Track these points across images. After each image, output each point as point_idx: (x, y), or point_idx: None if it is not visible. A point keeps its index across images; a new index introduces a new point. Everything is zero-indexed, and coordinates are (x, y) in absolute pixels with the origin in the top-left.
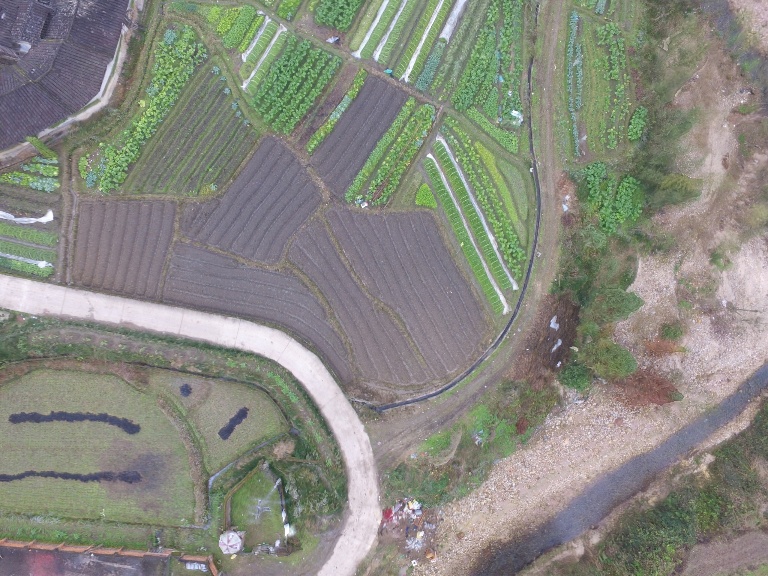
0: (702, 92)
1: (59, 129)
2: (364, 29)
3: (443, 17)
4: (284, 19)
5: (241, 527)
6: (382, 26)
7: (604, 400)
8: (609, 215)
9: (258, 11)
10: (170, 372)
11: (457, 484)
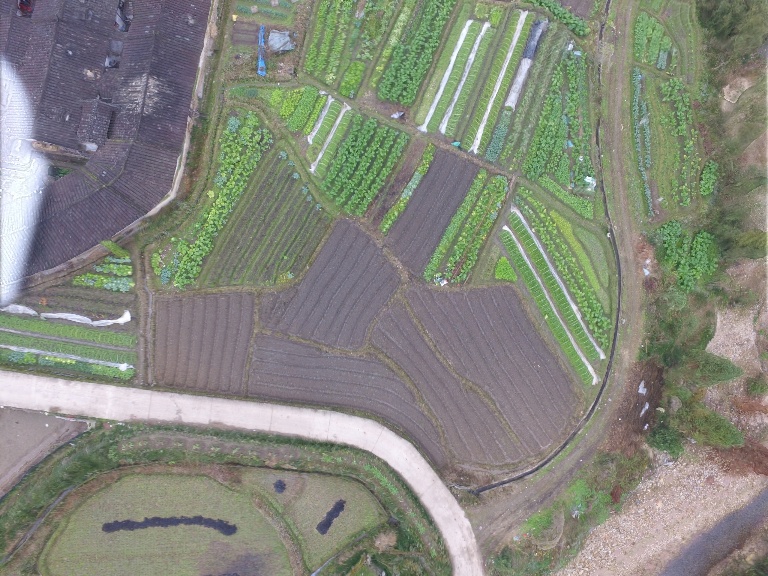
0: (767, 139)
1: (130, 227)
2: (428, 102)
3: (507, 85)
4: (347, 97)
5: None
6: (447, 98)
7: (694, 459)
8: (687, 273)
9: (320, 91)
10: (263, 469)
11: (558, 560)
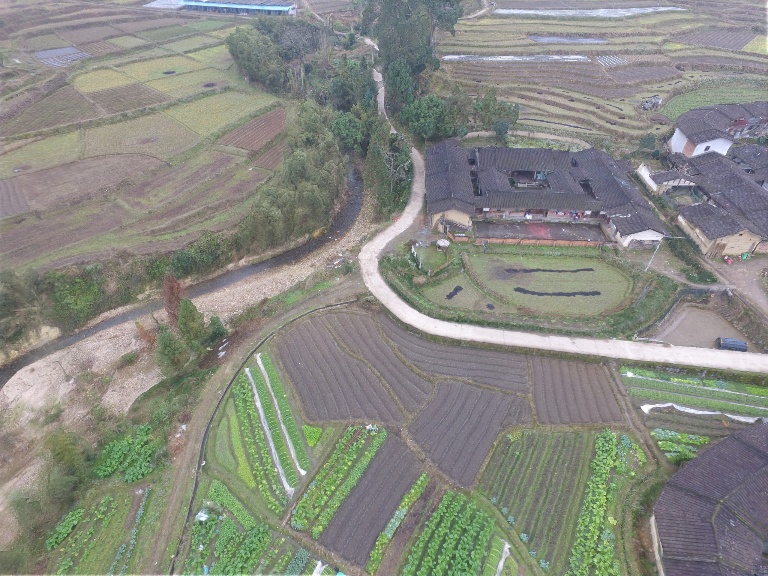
0: None
1: None
2: None
3: None
4: None
5: (440, 253)
6: None
7: None
8: None
9: None
10: None
11: None
